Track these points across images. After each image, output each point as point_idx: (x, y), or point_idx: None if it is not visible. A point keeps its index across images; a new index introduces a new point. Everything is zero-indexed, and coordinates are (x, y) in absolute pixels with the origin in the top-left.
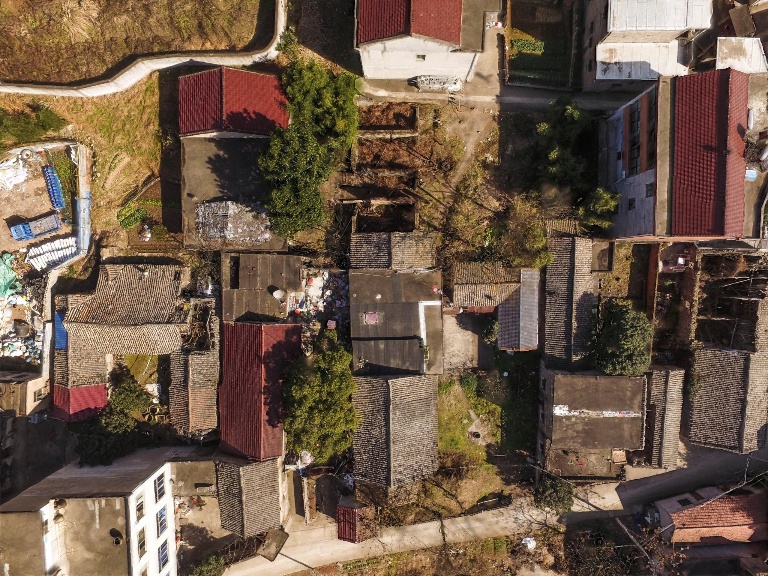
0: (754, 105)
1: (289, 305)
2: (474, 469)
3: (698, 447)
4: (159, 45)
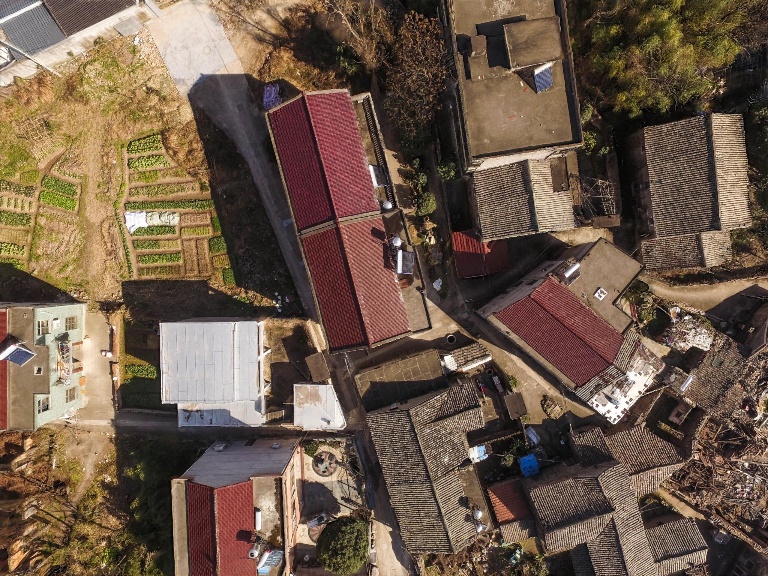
0: (263, 504)
1: None
2: None
3: None
4: None
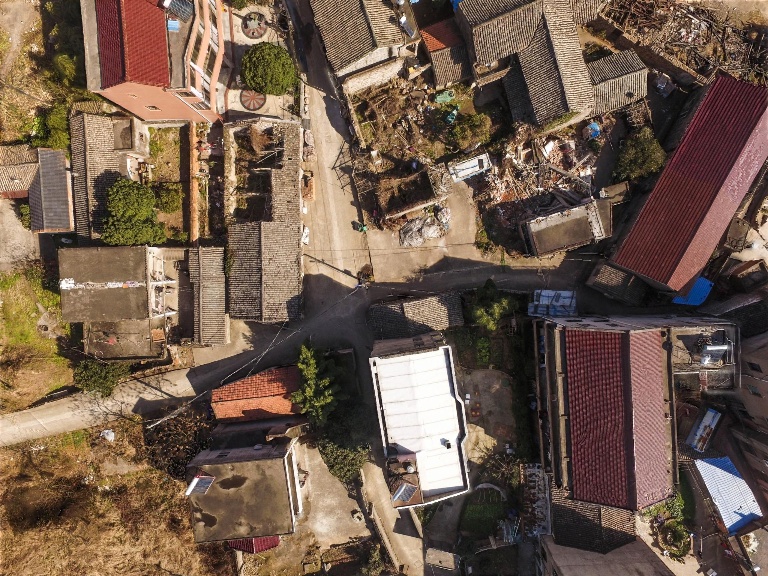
0: None
1: None
2: (39, 361)
3: (262, 328)
4: None
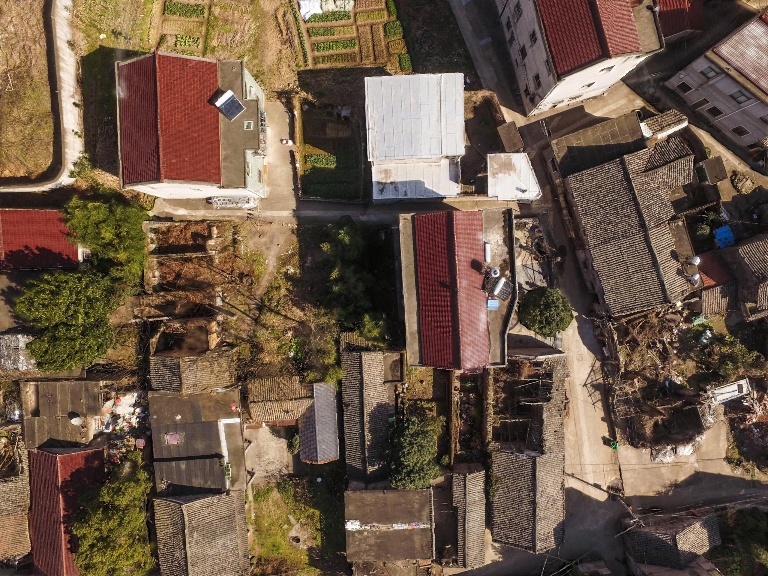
0: (491, 238)
1: (95, 427)
2: (294, 575)
3: None
4: None
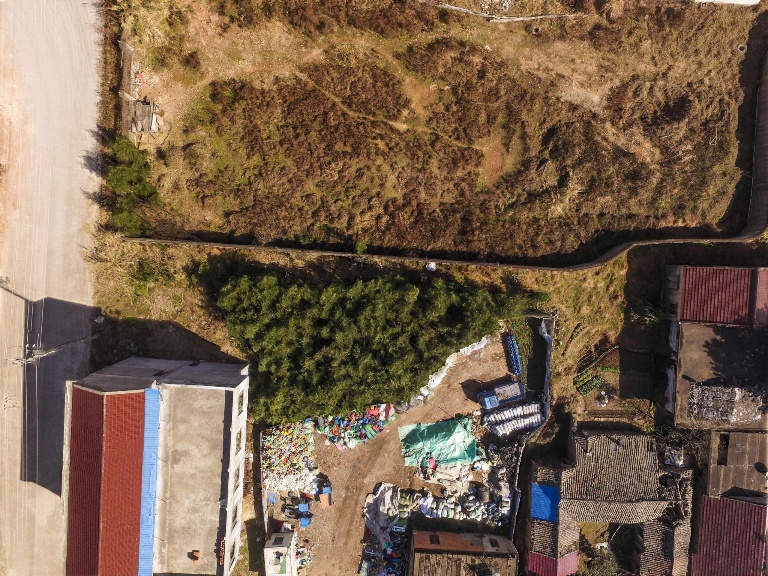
0: None
1: None
2: None
3: None
4: (637, 223)
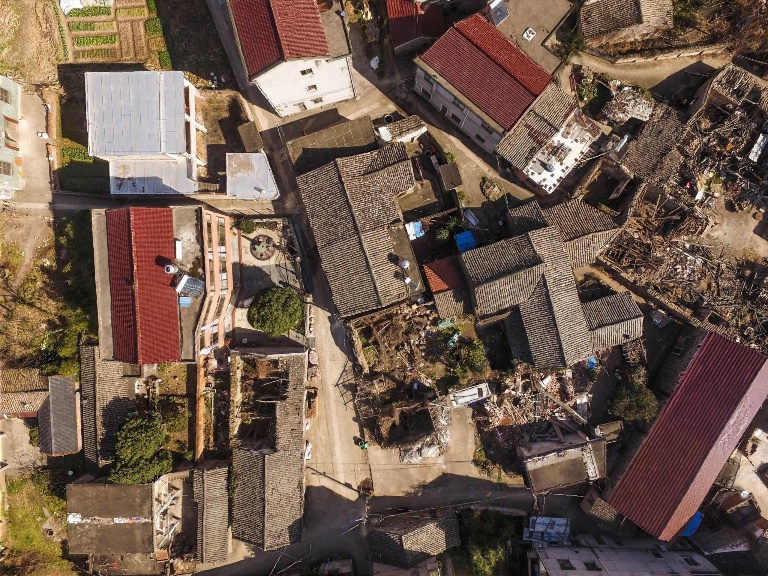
0: (184, 235)
1: None
2: (44, 567)
3: None
4: None
